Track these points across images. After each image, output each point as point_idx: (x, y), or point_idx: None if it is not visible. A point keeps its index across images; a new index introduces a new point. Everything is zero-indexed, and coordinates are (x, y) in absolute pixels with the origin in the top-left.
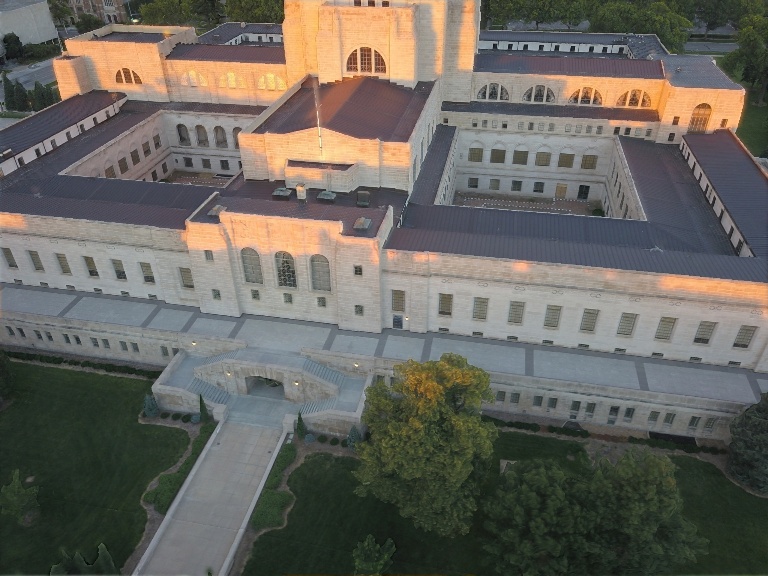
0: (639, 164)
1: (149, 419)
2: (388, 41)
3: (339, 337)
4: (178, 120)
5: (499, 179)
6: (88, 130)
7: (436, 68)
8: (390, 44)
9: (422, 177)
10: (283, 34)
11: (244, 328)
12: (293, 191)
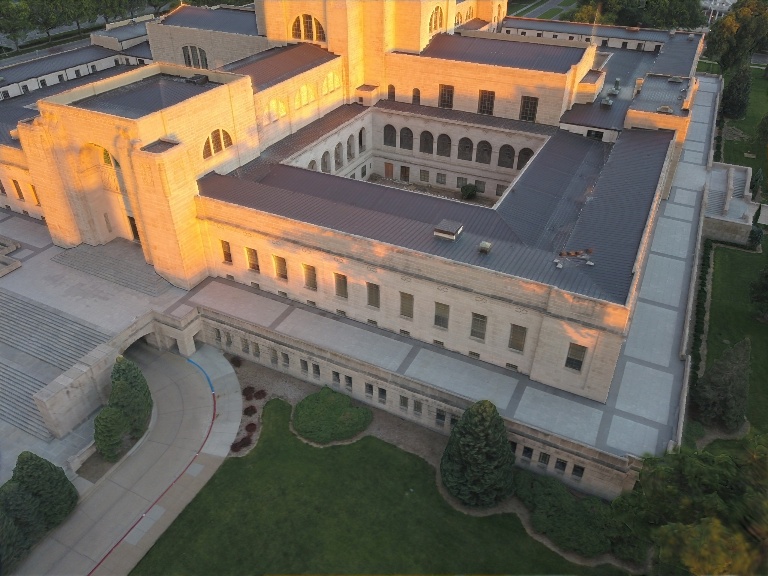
0: None
1: (758, 248)
2: None
3: (686, 160)
4: None
5: None
6: None
7: None
8: None
9: None
10: (347, 20)
11: (684, 186)
12: (594, 103)
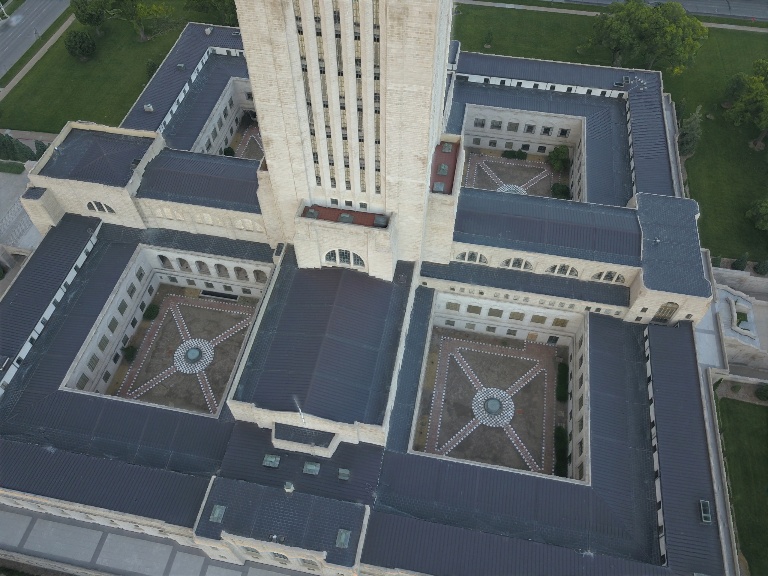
0: (600, 370)
1: None
2: (366, 249)
3: None
4: (158, 253)
5: (475, 324)
6: (72, 283)
7: (415, 253)
8: (368, 253)
9: (398, 399)
10: (258, 199)
11: None
12: (281, 450)
